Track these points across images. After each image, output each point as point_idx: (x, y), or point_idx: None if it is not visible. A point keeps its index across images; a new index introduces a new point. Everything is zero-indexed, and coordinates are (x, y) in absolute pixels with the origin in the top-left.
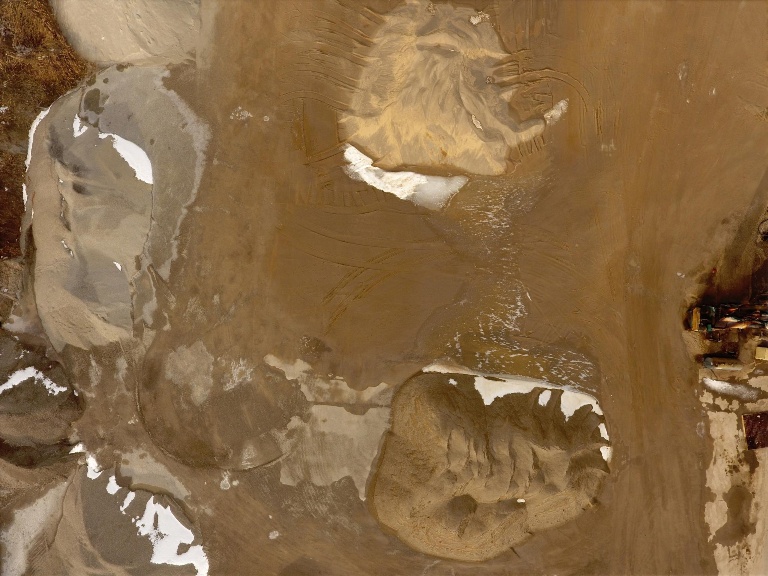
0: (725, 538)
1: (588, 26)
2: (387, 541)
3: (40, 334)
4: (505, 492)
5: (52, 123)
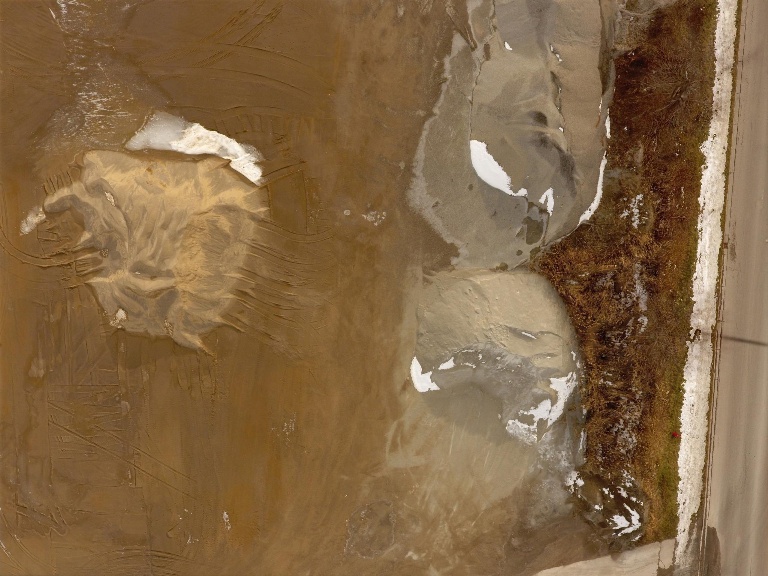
0: None
1: (4, 314)
2: None
3: None
4: None
5: (574, 200)
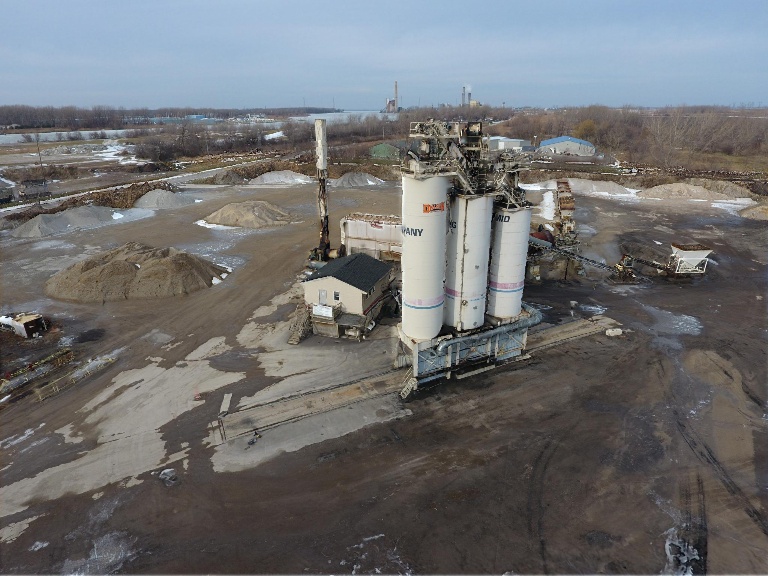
0: (261, 320)
1: None
2: (35, 289)
3: (6, 233)
4: (133, 254)
5: None
